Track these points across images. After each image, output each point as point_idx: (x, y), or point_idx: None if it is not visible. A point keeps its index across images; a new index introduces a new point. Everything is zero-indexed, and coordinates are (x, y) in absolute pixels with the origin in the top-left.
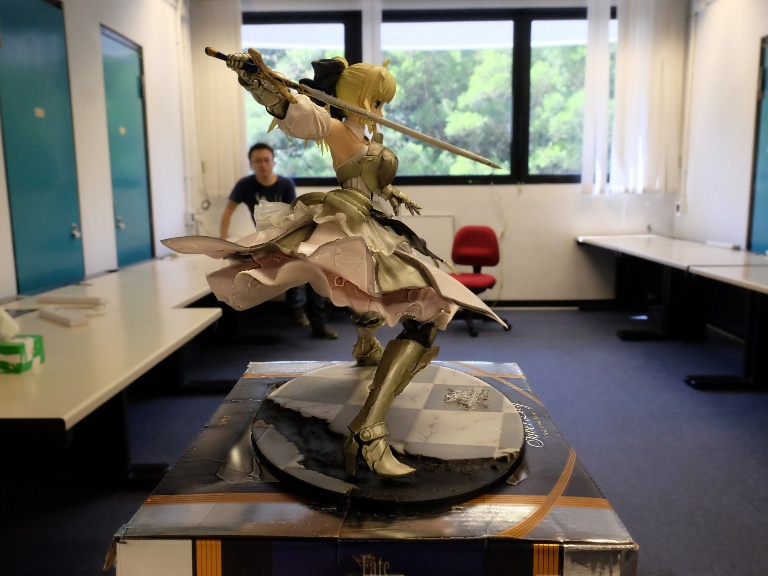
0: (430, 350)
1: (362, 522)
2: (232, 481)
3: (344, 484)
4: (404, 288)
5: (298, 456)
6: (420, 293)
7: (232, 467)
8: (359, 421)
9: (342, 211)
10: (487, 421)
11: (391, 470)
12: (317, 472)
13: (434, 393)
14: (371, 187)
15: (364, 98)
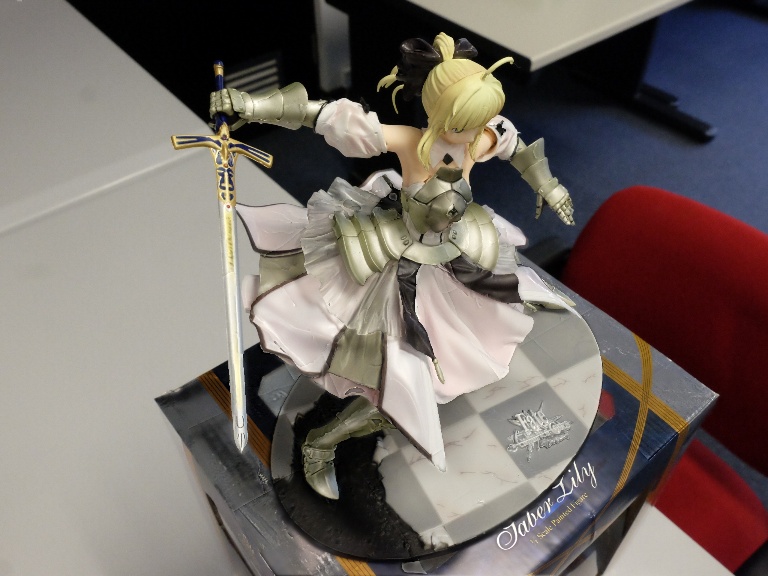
0: None
1: (259, 512)
2: (264, 391)
3: (287, 468)
4: (350, 379)
5: (309, 406)
6: None
7: (290, 369)
8: (318, 434)
9: (344, 263)
10: (495, 480)
11: (317, 487)
12: (293, 437)
13: (523, 397)
14: (420, 228)
15: (429, 126)
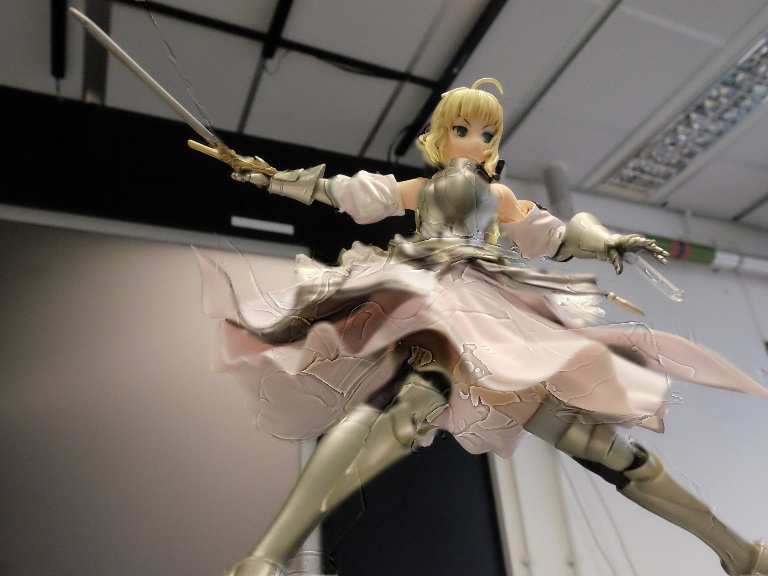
0: (444, 393)
1: None
2: None
3: None
4: (343, 287)
5: None
6: (428, 300)
7: None
8: None
9: (350, 253)
10: None
11: None
12: None
13: None
14: (446, 220)
15: None
